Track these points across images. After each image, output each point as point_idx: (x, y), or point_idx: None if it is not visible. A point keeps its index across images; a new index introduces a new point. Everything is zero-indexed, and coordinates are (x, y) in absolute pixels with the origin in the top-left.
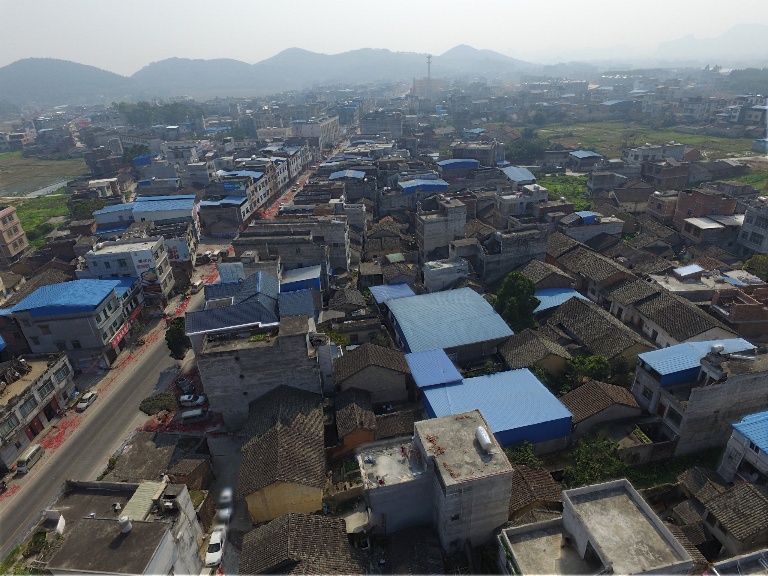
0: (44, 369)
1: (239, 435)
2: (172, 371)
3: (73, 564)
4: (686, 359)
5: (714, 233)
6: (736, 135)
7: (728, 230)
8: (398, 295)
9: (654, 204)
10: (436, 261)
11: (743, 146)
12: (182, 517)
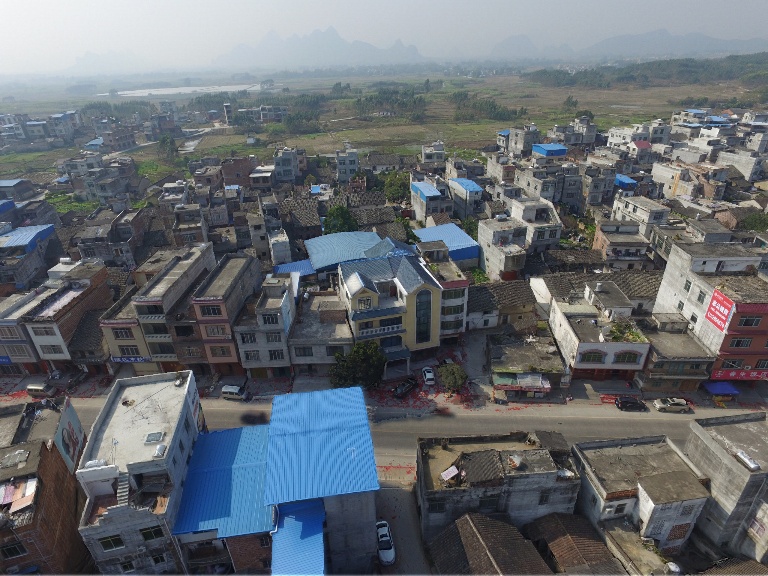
0: (447, 453)
1: (463, 341)
2: (373, 413)
3: (625, 300)
4: (431, 189)
5: (271, 177)
6: (48, 147)
7: (272, 174)
8: (303, 266)
9: (202, 181)
10: (270, 239)
11: (74, 153)
12: (573, 291)
